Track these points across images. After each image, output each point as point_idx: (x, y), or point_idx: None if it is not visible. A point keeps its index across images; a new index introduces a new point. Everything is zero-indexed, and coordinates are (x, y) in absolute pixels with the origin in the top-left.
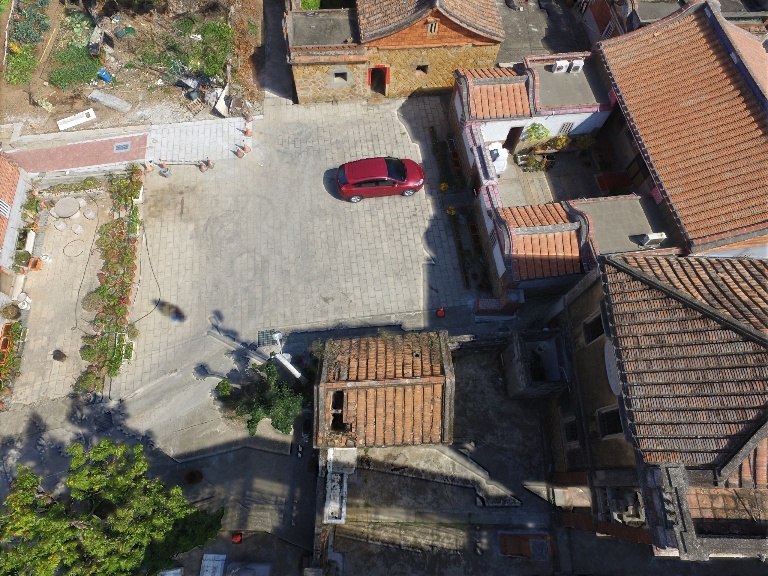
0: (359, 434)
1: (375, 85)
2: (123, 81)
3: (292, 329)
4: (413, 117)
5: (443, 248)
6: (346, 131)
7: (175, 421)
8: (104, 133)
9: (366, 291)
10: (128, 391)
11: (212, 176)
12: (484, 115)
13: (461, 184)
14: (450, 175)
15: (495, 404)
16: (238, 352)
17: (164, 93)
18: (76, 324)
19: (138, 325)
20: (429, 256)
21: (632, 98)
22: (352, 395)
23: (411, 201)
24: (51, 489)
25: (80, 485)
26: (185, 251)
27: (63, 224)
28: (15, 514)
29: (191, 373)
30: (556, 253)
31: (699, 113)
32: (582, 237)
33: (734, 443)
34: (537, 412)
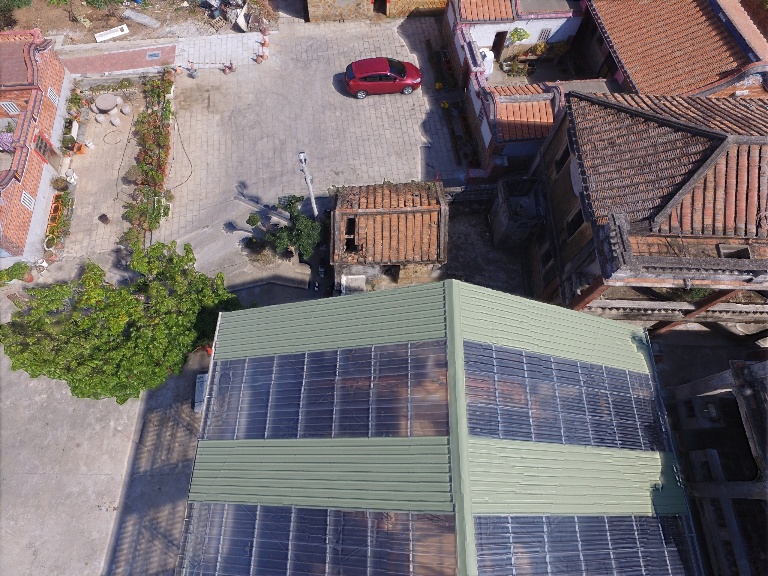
0: (369, 252)
1: (377, 6)
2: (152, 3)
3: (308, 195)
4: (411, 33)
5: (438, 135)
6: (352, 44)
7: (208, 264)
8: (137, 44)
9: (371, 167)
10: (167, 241)
11: (234, 78)
12: (473, 18)
13: (453, 83)
14: (444, 77)
15: (483, 253)
16: (261, 212)
17: (189, 13)
18: (117, 196)
19: (173, 192)
20: (426, 141)
21: (599, 1)
22: (363, 220)
23: (410, 98)
24: None
25: (142, 268)
26: (213, 136)
27: (103, 117)
28: (89, 288)
29: (221, 228)
30: (534, 119)
31: (655, 8)
32: (555, 105)
33: (665, 200)
34: (519, 259)
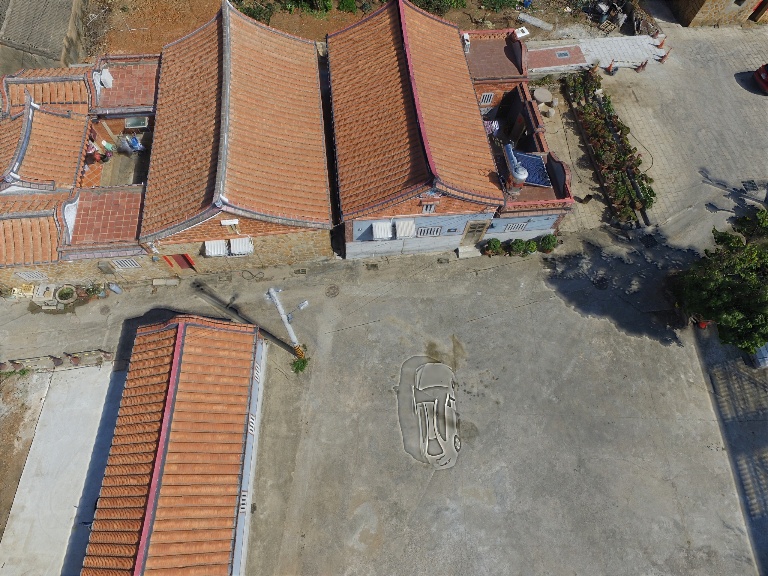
0: None
1: None
2: (538, 8)
3: (767, 180)
4: None
5: None
6: (736, 47)
7: (708, 239)
8: (545, 44)
9: None
10: (662, 219)
11: (647, 76)
12: None
13: None
14: None
15: None
16: (734, 195)
17: (574, 17)
18: (580, 179)
19: None
20: None
21: None
22: None
23: None
24: (628, 285)
25: None
26: (655, 127)
27: None
28: None
29: (704, 208)
30: None
31: None
32: None
33: None
34: None
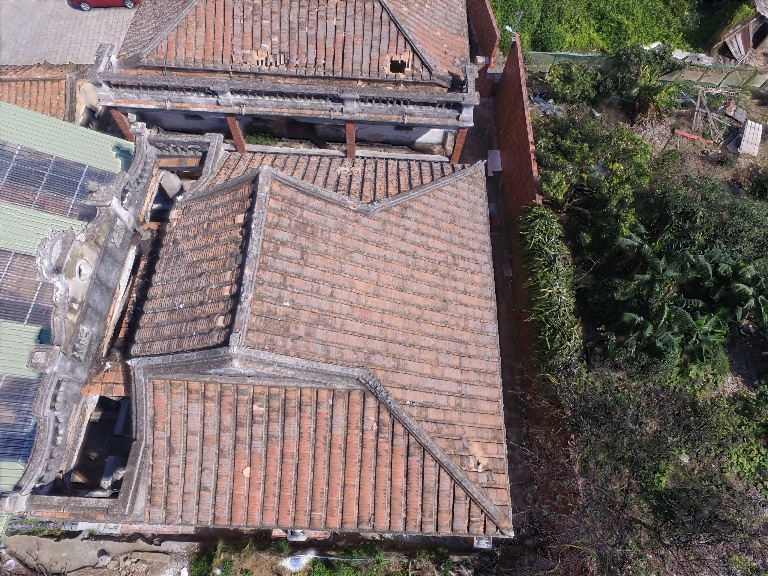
0: None
1: None
2: None
3: None
4: None
5: None
6: None
7: None
8: None
9: None
10: None
11: None
12: None
13: None
14: None
15: None
16: None
17: None
18: None
19: None
20: None
21: None
22: None
23: (132, 12)
24: None
25: None
26: None
27: None
28: None
29: None
30: None
31: None
32: None
33: None
34: None
